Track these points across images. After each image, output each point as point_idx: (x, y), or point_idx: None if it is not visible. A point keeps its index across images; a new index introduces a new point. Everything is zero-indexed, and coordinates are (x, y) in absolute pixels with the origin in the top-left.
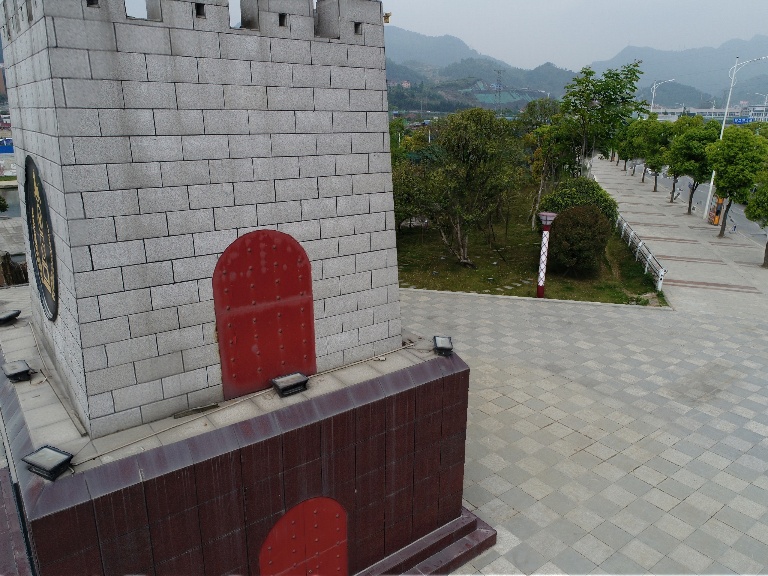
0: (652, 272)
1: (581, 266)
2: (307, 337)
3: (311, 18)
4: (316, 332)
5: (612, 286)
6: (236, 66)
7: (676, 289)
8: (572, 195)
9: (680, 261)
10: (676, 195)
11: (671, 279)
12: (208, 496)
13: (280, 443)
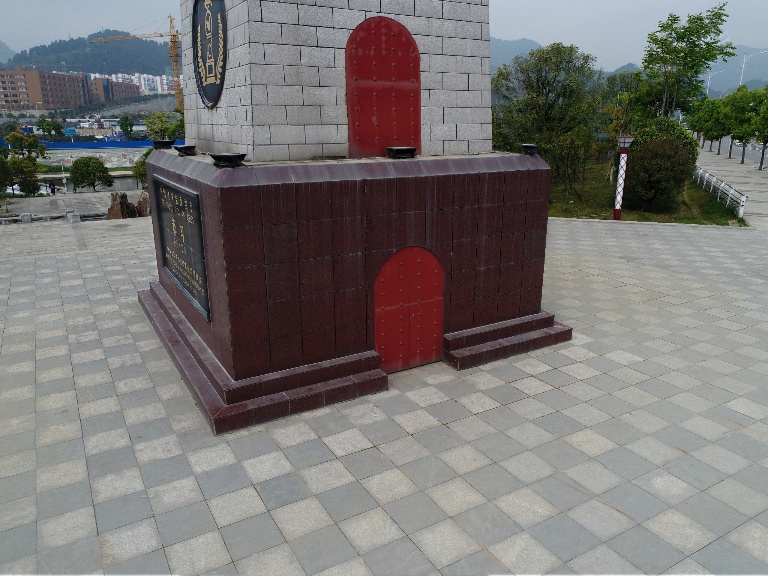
0: (733, 203)
1: (659, 198)
2: (415, 121)
3: None
4: (422, 118)
5: (691, 217)
6: None
7: (759, 218)
8: (651, 133)
9: (765, 203)
10: (766, 166)
11: (754, 213)
12: (339, 214)
13: (395, 186)
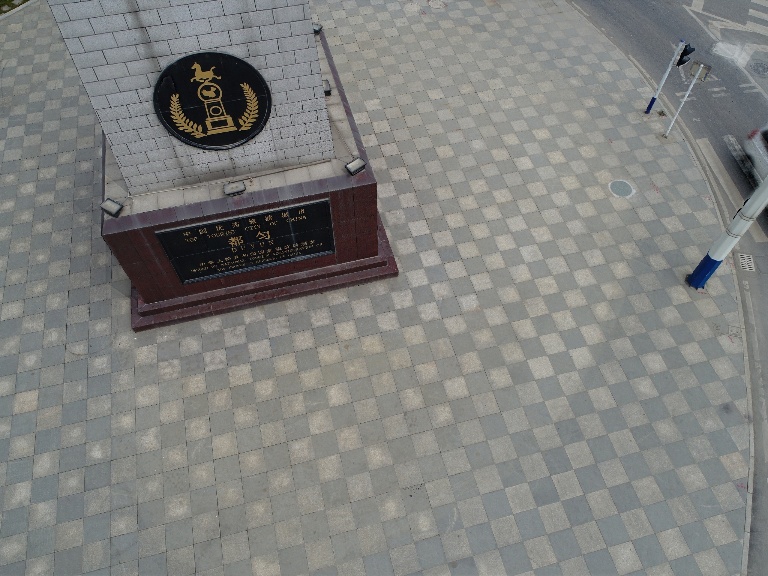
0: None
1: None
2: None
3: None
4: None
5: None
6: None
7: None
8: None
9: None
10: None
11: None
12: None
13: None
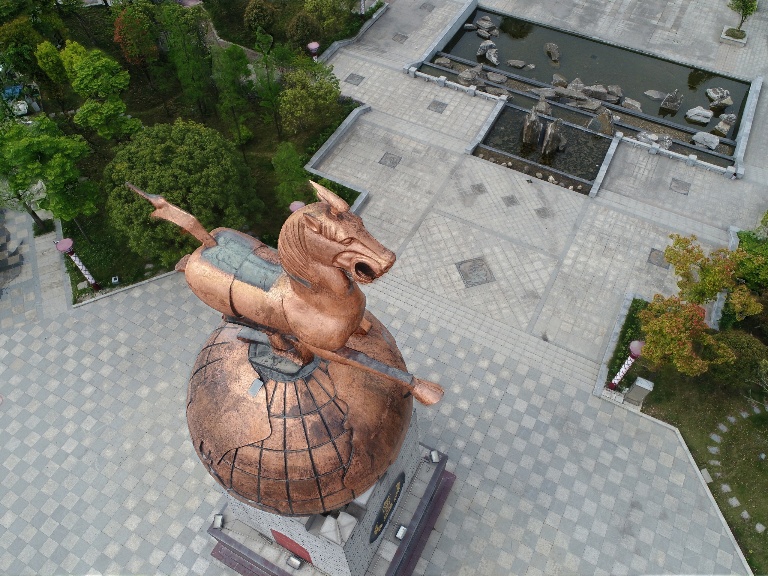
0: None
1: None
2: None
3: None
4: None
5: None
6: (274, 515)
7: None
8: None
9: None
10: None
11: None
12: None
13: None
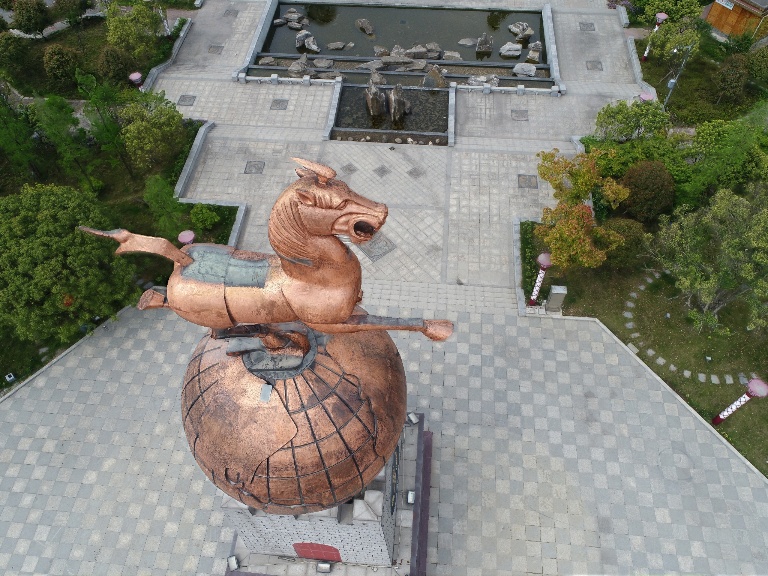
0: None
1: None
2: None
3: (337, 521)
4: (342, 557)
5: None
6: None
7: None
8: None
9: None
10: None
11: None
12: None
13: None
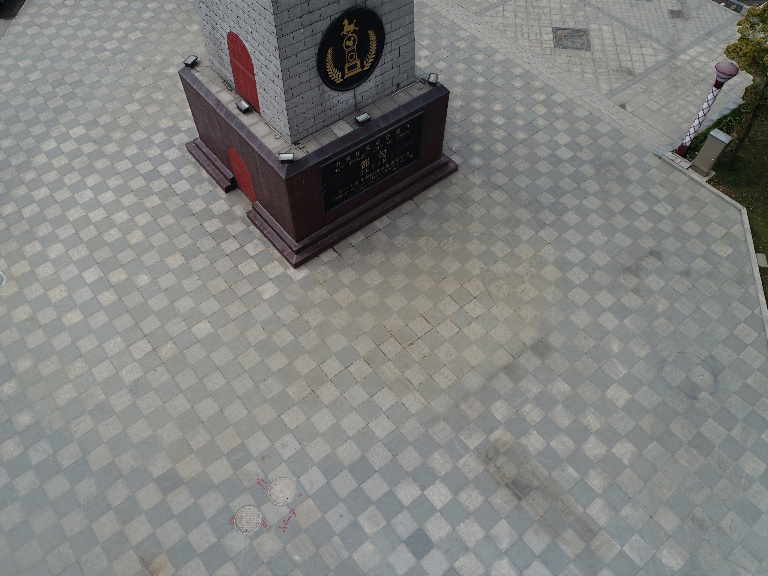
0: None
1: None
2: (256, 96)
3: None
4: None
5: None
6: None
7: None
8: None
9: None
10: None
11: None
12: None
13: None
